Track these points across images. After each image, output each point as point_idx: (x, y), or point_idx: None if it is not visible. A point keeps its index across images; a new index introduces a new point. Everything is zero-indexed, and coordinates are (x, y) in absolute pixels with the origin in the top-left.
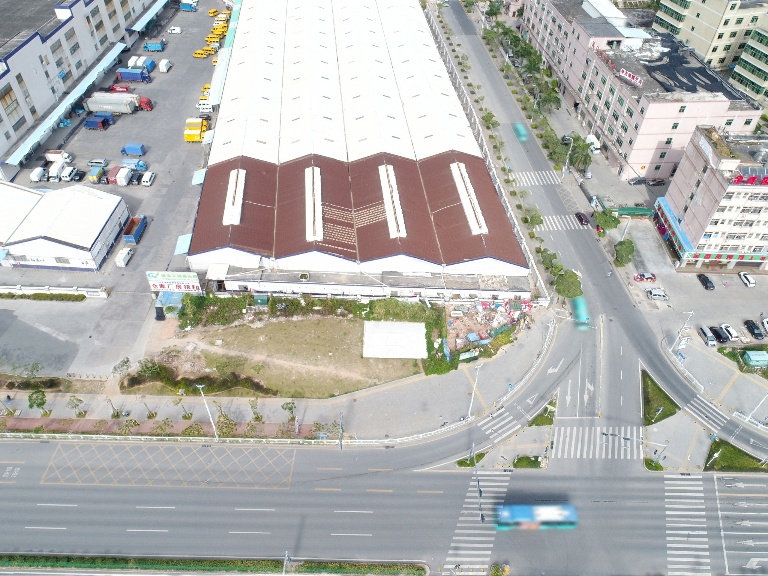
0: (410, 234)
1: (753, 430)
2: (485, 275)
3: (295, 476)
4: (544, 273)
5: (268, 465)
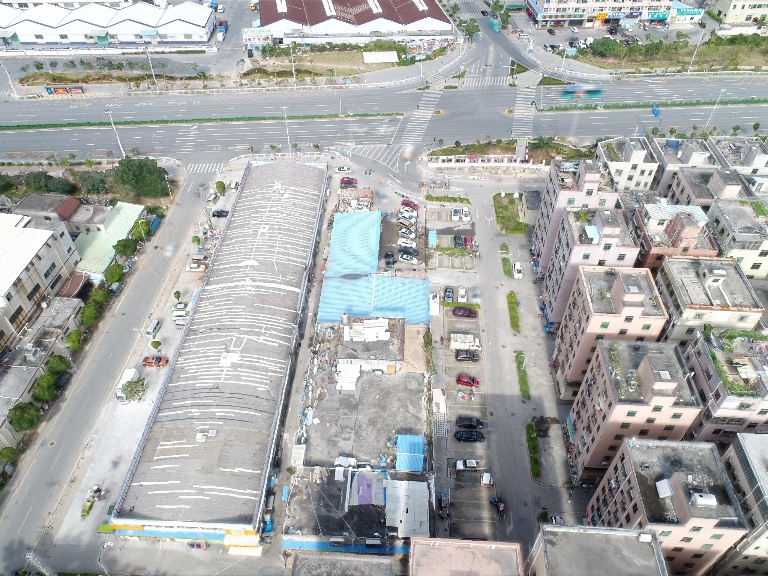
0: (384, 12)
1: (564, 75)
2: (428, 30)
3: (337, 97)
4: (461, 33)
5: (323, 95)
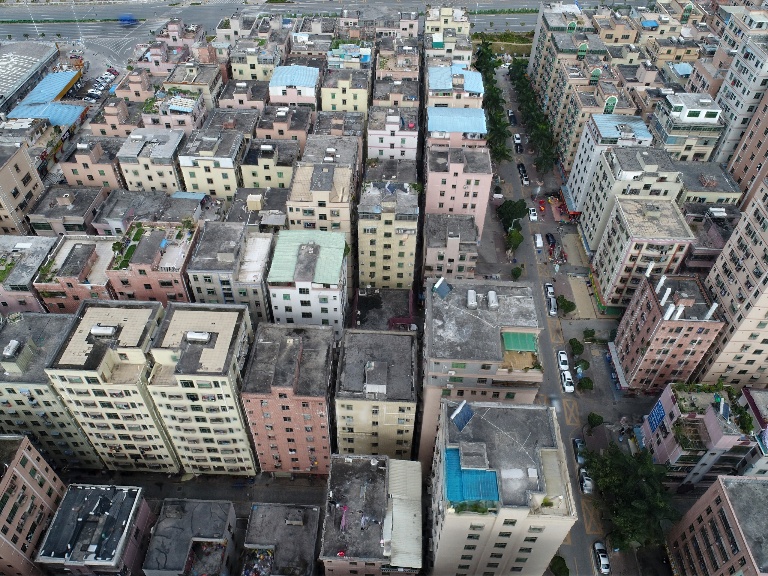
0: None
1: None
2: None
3: (104, 9)
4: None
5: (94, 8)
